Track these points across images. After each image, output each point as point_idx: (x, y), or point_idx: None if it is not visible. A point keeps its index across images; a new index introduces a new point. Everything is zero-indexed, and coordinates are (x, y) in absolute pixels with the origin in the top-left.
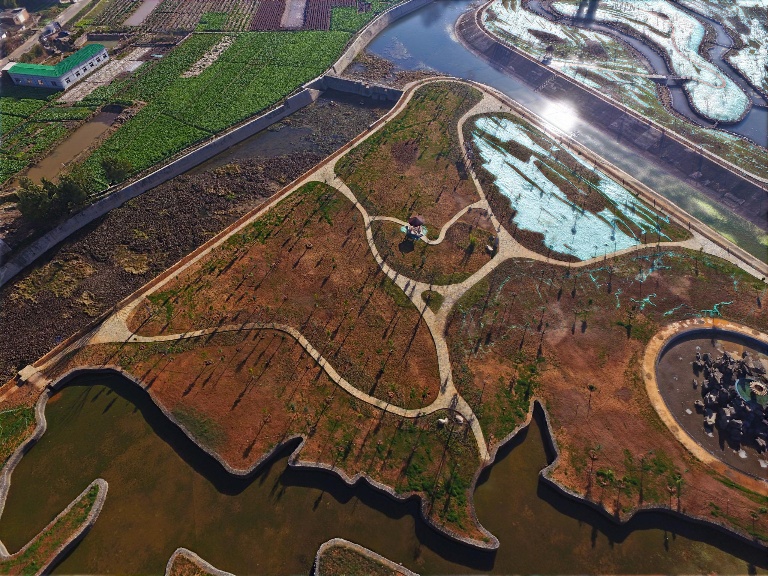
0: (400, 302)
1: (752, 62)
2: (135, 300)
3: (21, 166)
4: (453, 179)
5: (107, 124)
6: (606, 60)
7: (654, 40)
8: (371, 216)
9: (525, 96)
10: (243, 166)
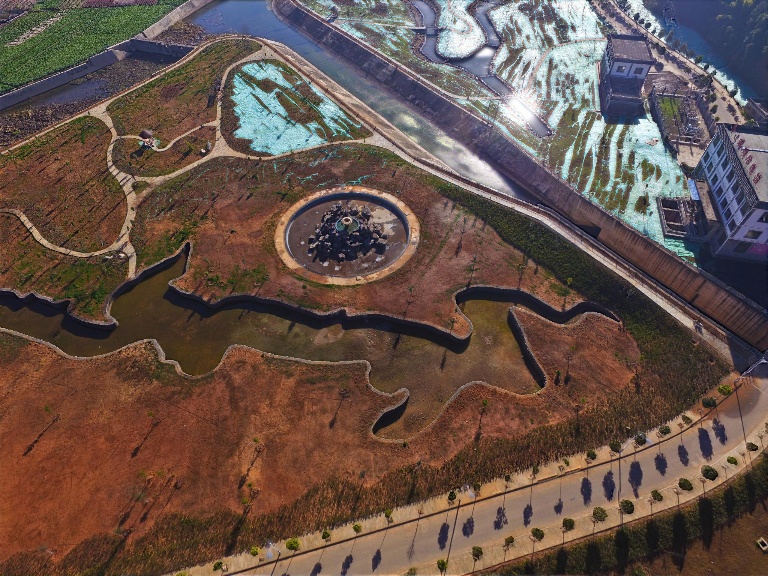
0: (113, 189)
1: (504, 13)
2: None
3: None
4: (201, 107)
5: None
6: (384, 17)
7: (436, 1)
8: (119, 136)
9: (307, 49)
10: (35, 111)
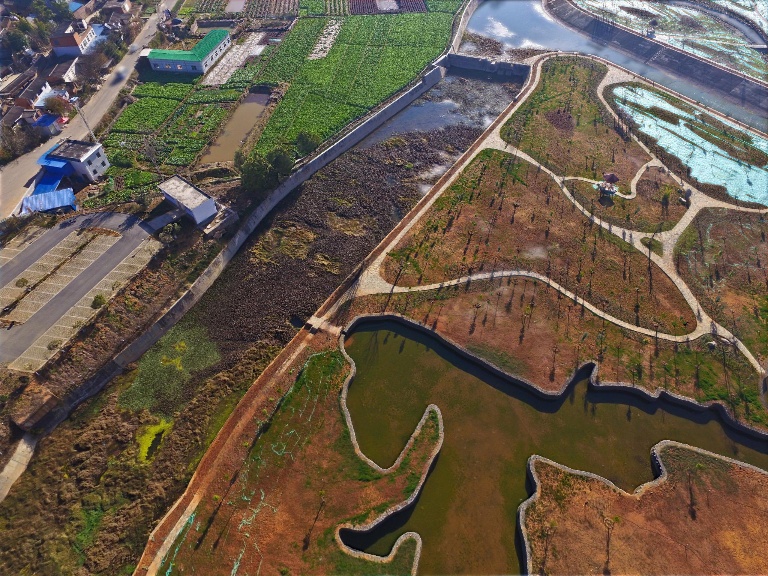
0: (625, 248)
1: None
2: (378, 257)
3: (202, 144)
4: (618, 142)
5: (261, 104)
6: (705, 32)
7: (739, 13)
8: (560, 177)
9: (639, 68)
10: (407, 138)
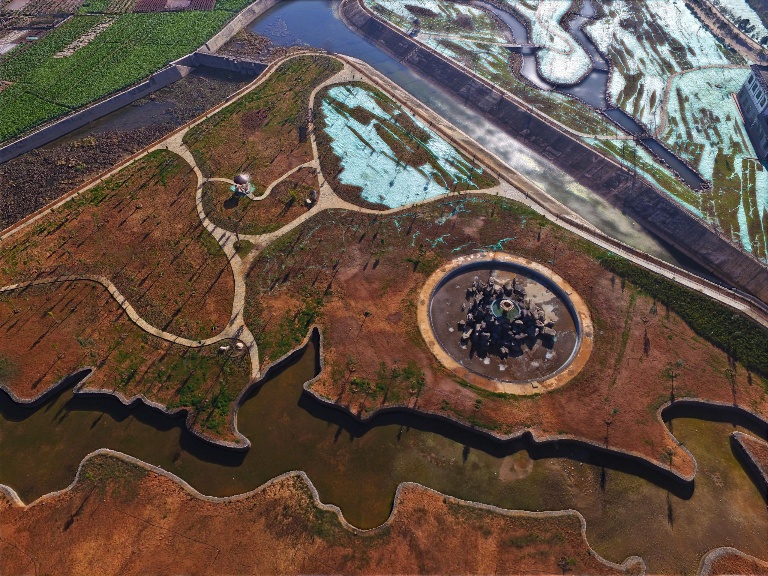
0: (212, 251)
1: (604, 30)
2: None
3: None
4: (292, 142)
5: None
6: (471, 32)
7: (522, 13)
8: (205, 178)
9: (390, 67)
10: (99, 139)
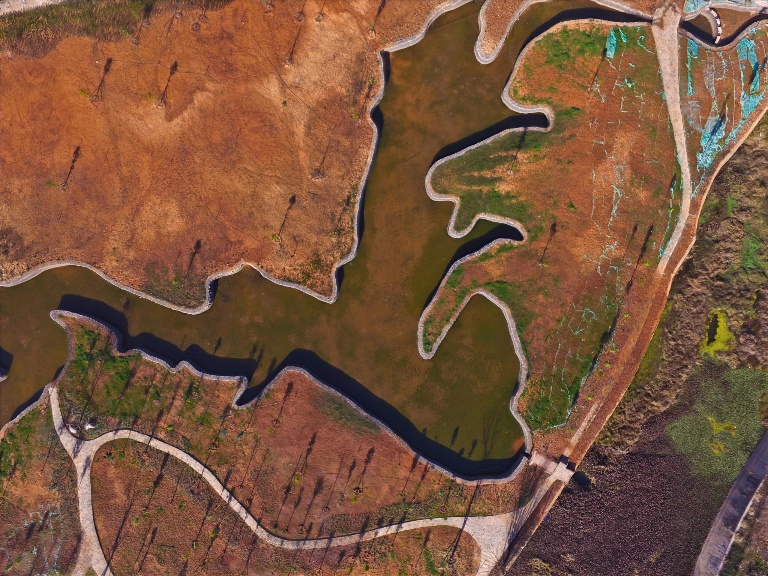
0: None
1: None
2: None
3: None
4: None
5: None
6: None
7: None
8: None
9: None
10: None
